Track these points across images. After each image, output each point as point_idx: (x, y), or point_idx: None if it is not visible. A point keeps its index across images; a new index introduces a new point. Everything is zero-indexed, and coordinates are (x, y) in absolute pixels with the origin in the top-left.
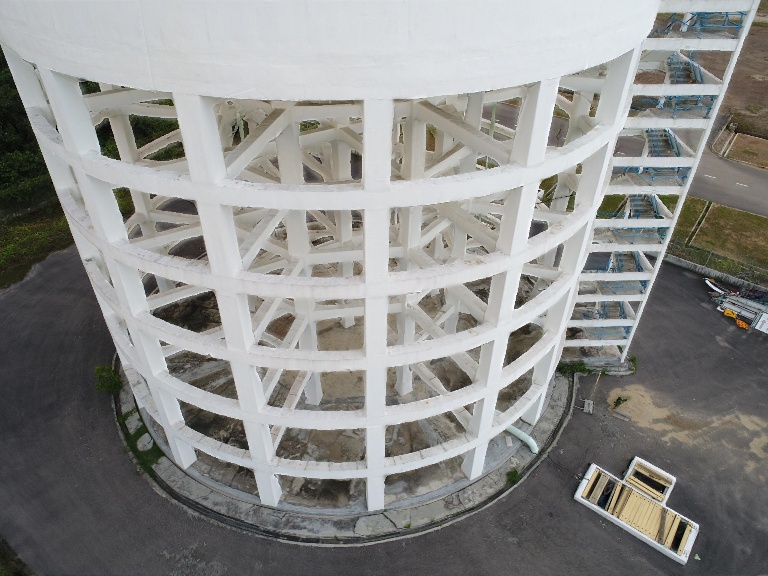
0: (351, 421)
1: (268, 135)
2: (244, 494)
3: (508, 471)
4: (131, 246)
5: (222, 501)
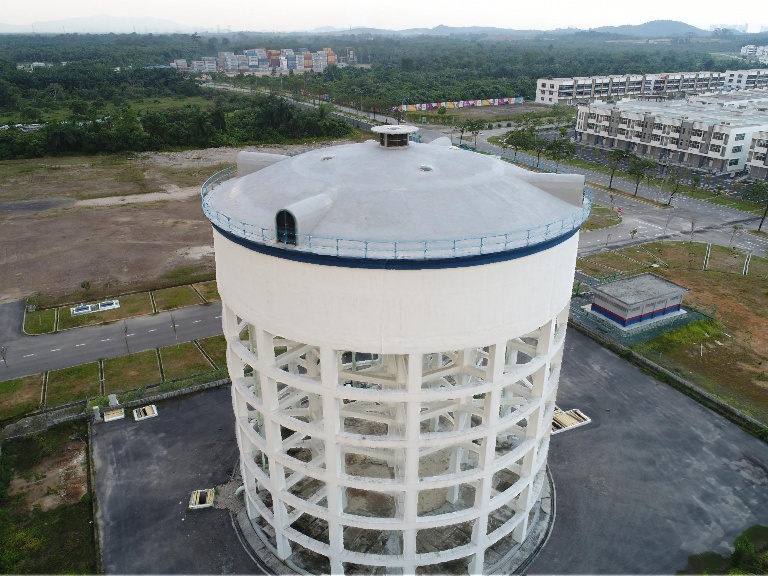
0: None
1: None
2: (512, 550)
3: None
4: (503, 418)
5: (510, 565)
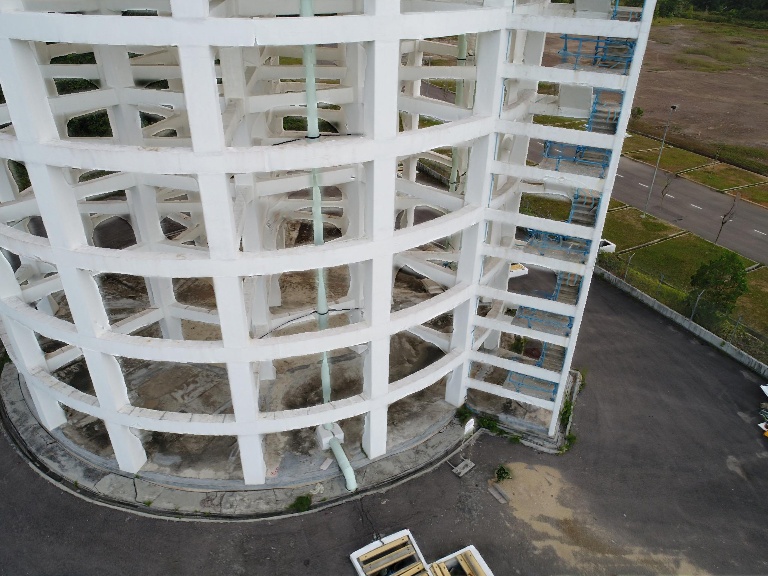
0: (64, 333)
1: (43, 2)
2: None
3: (302, 495)
4: None
5: (21, 411)
